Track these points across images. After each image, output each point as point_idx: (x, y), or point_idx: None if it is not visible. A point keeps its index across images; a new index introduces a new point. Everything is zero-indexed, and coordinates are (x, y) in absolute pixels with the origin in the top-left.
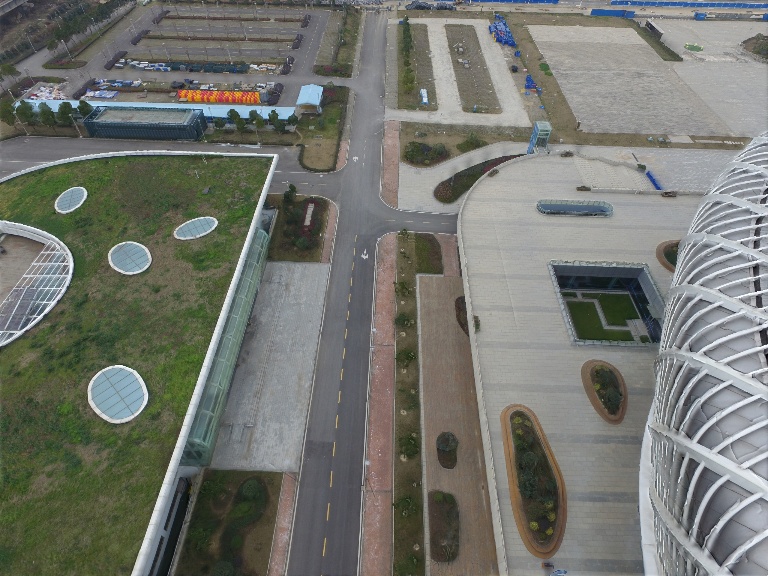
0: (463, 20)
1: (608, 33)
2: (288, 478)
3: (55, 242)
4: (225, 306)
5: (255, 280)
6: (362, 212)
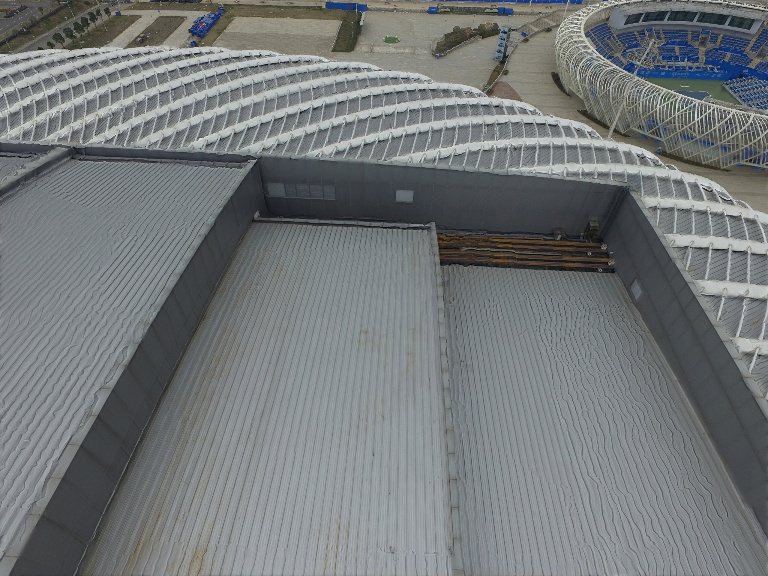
0: (184, 12)
1: (308, 25)
2: None
3: None
4: None
5: None
6: None
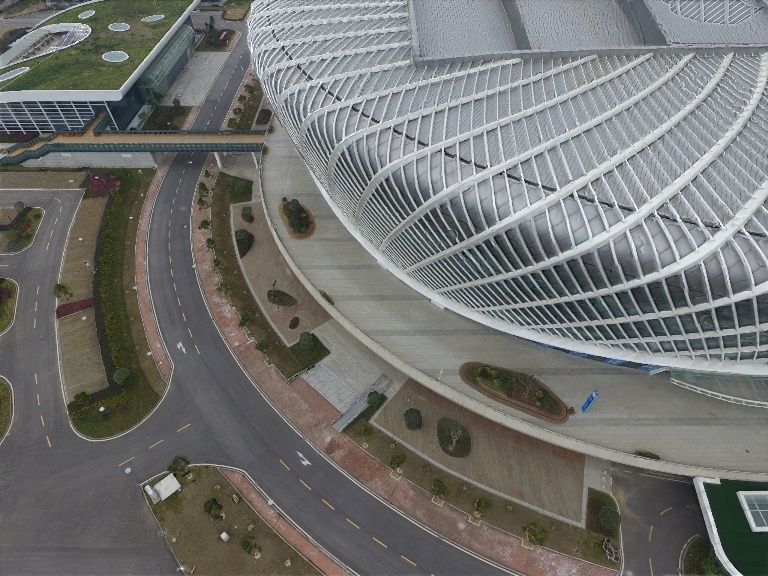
0: None
1: None
2: (195, 107)
3: (81, 25)
4: (165, 36)
5: (185, 44)
6: None
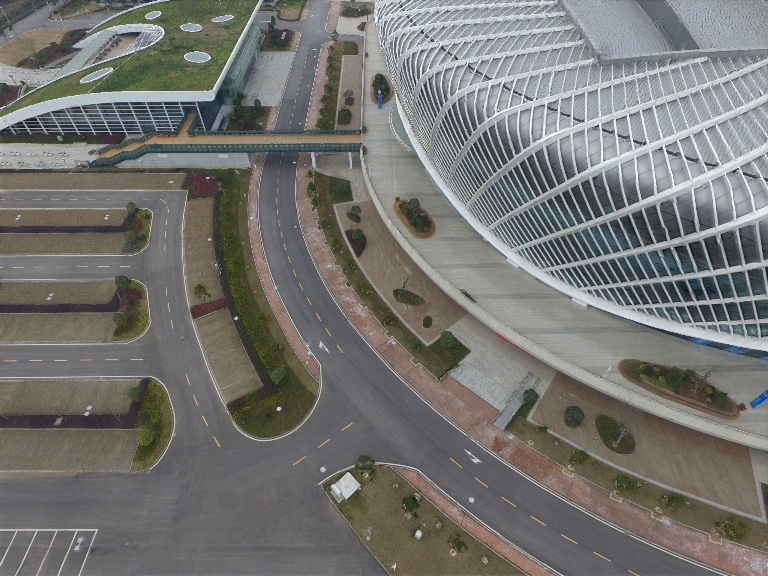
0: None
1: None
2: (274, 108)
3: (151, 26)
4: (241, 36)
5: (254, 45)
6: (314, 35)
